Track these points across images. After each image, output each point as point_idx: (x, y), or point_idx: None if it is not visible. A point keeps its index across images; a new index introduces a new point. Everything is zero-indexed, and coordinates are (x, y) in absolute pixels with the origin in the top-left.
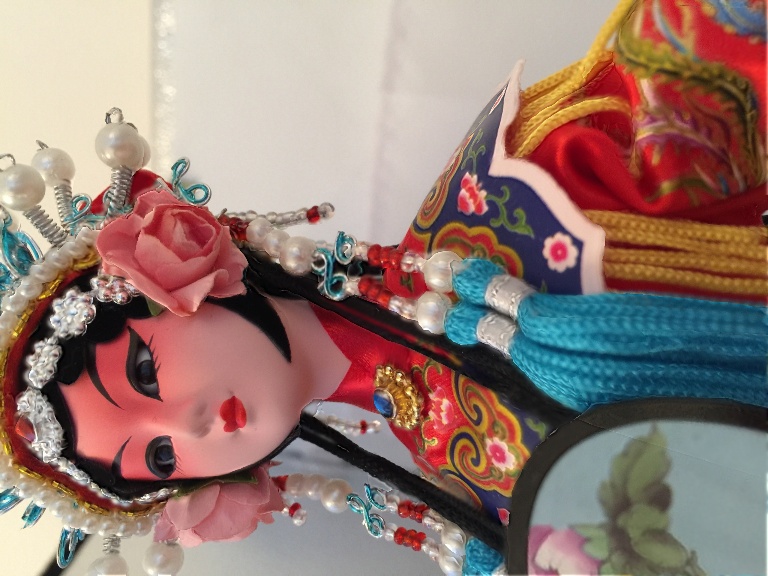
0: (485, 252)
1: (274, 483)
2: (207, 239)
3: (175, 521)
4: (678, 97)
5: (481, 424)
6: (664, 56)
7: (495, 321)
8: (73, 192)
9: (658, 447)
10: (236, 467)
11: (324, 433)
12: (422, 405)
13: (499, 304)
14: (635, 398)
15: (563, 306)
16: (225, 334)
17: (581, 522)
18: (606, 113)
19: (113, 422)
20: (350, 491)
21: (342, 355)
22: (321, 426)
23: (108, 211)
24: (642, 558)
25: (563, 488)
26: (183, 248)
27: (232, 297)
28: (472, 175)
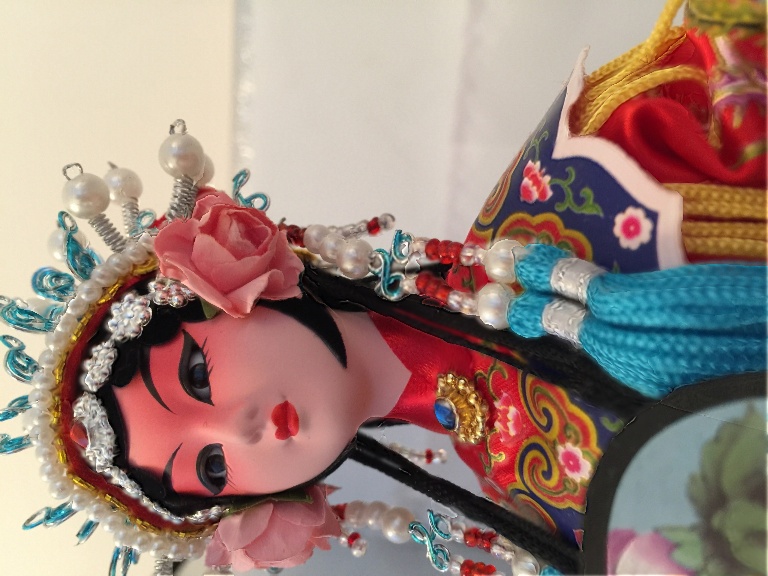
0: (550, 239)
1: (332, 510)
2: (262, 239)
3: (226, 541)
4: (759, 54)
5: (551, 429)
6: (740, 10)
7: (562, 307)
8: (140, 209)
9: (758, 431)
10: (290, 483)
11: (385, 456)
12: (487, 414)
13: (566, 288)
14: (727, 375)
15: (638, 282)
16: (279, 337)
17: (669, 525)
18: (678, 82)
19: (164, 427)
20: (412, 519)
21: (402, 365)
22: (382, 448)
23: (169, 219)
24: (746, 567)
25: (646, 485)
26: (238, 247)
27: (287, 300)
28: (535, 162)
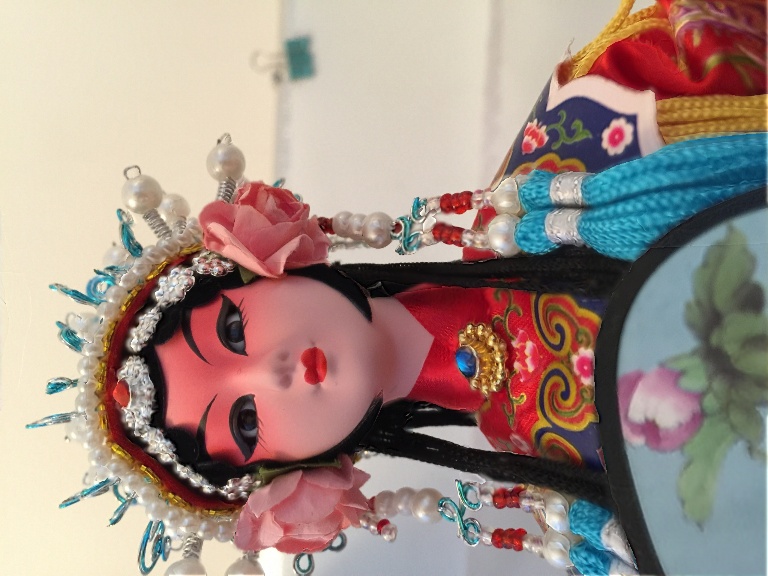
0: None
1: None
2: (295, 211)
3: (256, 510)
4: None
5: (565, 342)
6: None
7: (562, 212)
8: None
9: (739, 246)
10: (318, 442)
11: (413, 440)
12: (505, 354)
13: (564, 196)
14: (705, 209)
15: None
16: (309, 294)
17: (672, 356)
18: (646, 30)
19: (201, 378)
20: (441, 496)
21: (424, 330)
22: (410, 433)
23: None
24: (747, 375)
25: (646, 324)
26: (273, 215)
27: (317, 265)
28: (532, 121)
